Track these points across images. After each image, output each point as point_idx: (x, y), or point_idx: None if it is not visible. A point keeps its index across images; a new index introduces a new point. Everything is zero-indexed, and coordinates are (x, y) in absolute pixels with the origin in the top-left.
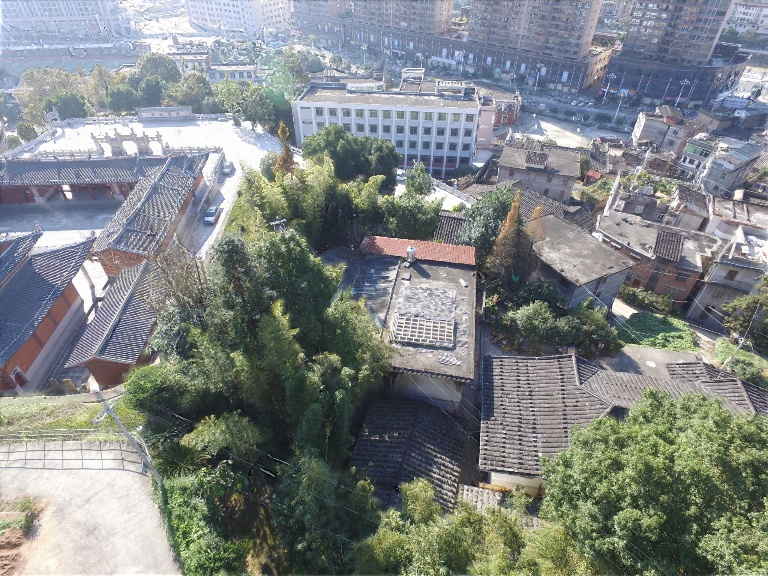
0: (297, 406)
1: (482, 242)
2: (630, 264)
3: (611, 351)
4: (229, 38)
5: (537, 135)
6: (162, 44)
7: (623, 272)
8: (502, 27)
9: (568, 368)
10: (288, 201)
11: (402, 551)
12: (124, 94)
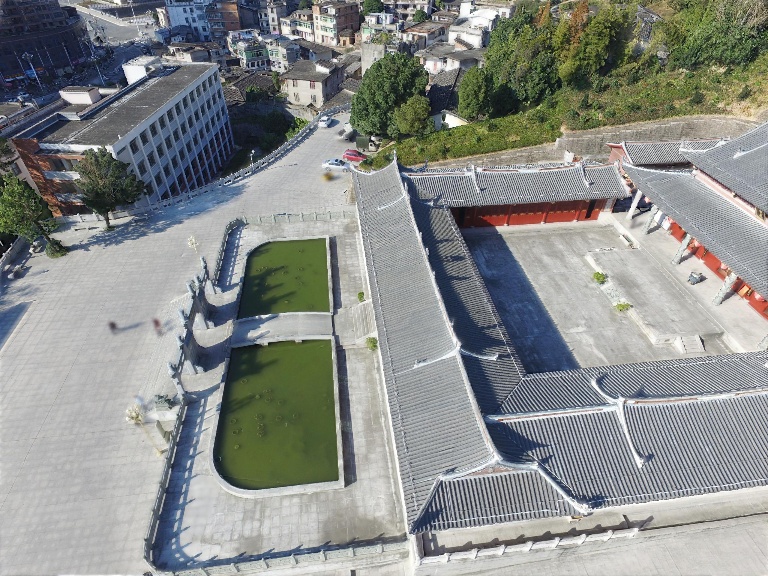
0: None
1: None
2: None
3: None
4: None
5: None
6: None
7: None
8: None
9: None
10: None
11: None
12: None
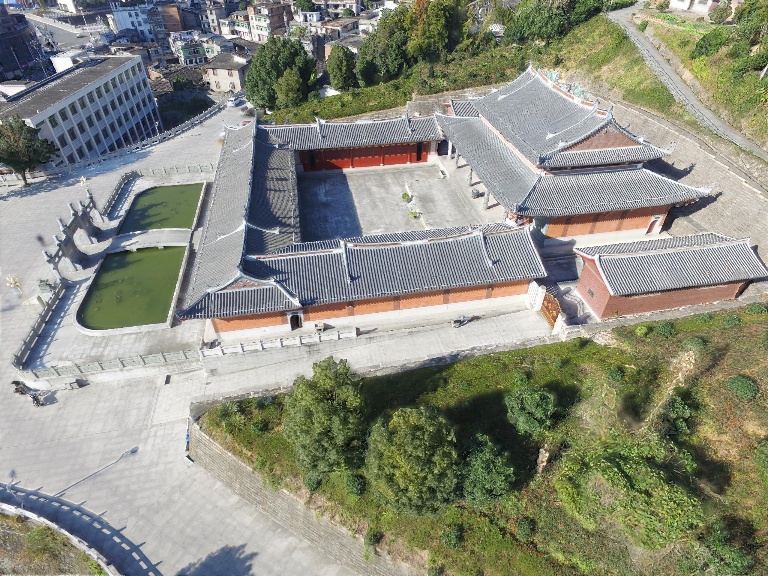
0: None
1: None
2: None
3: None
4: None
5: None
6: None
7: None
8: None
9: None
10: None
11: None
12: None
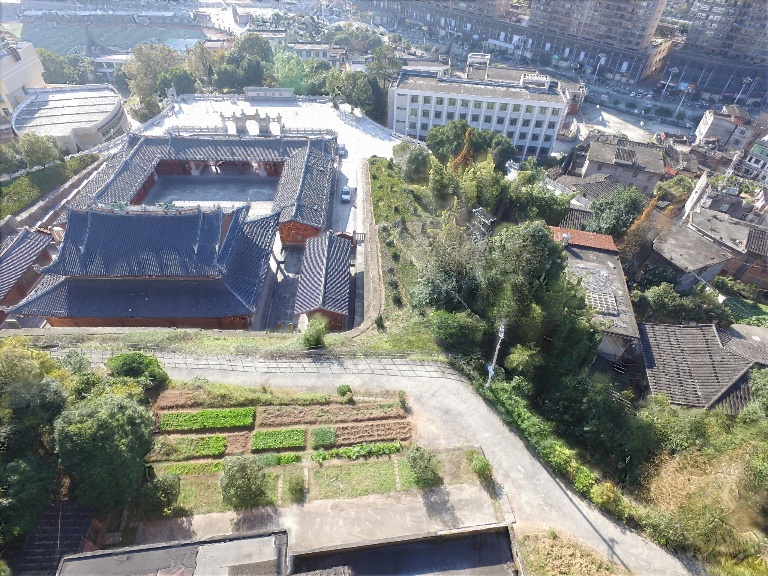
0: (567, 343)
1: (611, 232)
2: (729, 256)
3: (722, 326)
4: (286, 11)
5: (600, 126)
6: (221, 14)
7: (721, 263)
8: (565, 14)
9: (710, 334)
10: (478, 192)
11: (660, 433)
12: (230, 73)
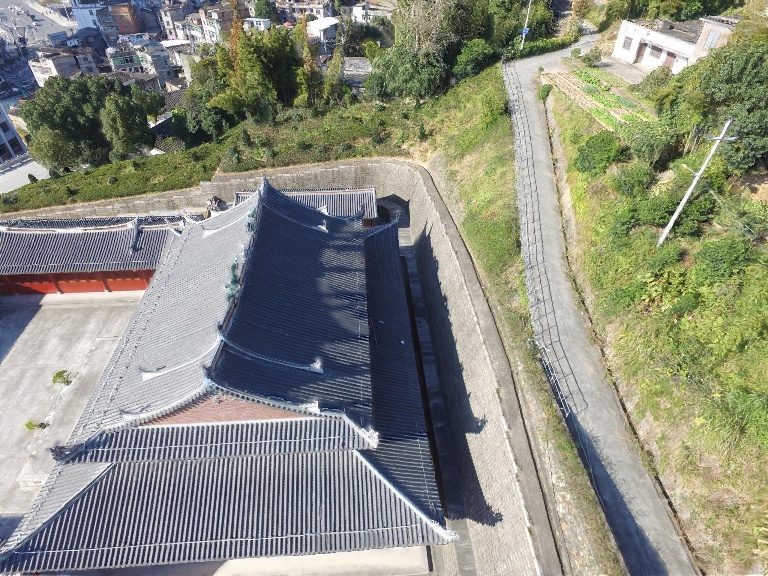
0: None
1: None
2: None
3: None
4: None
5: None
6: None
7: None
8: None
9: None
10: None
11: None
12: None
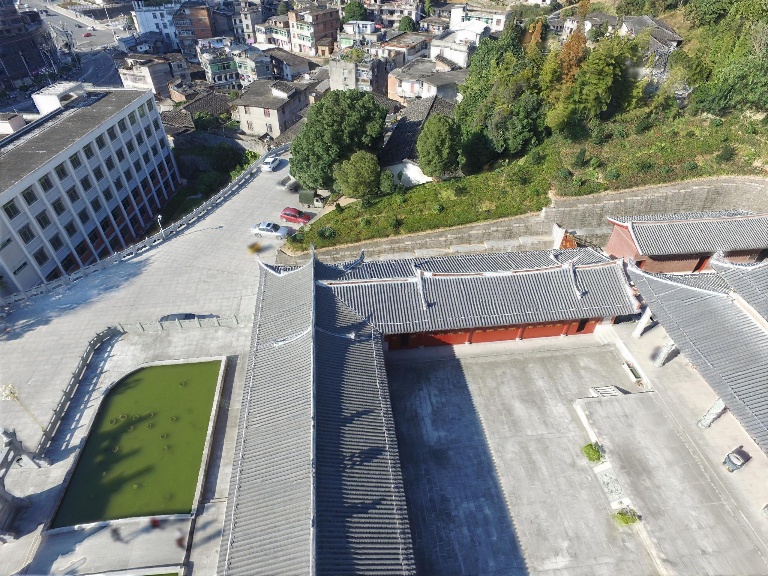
0: None
1: None
2: None
3: None
4: None
5: None
6: None
7: None
8: None
9: None
10: None
11: None
12: None
